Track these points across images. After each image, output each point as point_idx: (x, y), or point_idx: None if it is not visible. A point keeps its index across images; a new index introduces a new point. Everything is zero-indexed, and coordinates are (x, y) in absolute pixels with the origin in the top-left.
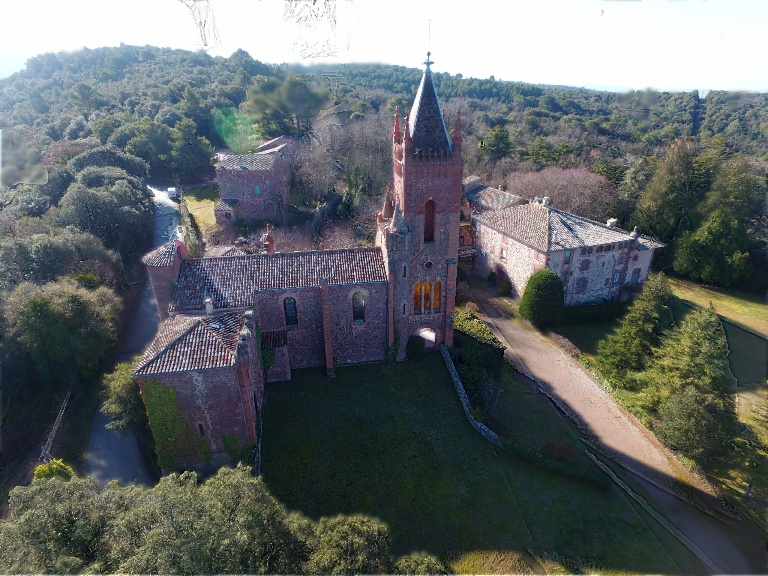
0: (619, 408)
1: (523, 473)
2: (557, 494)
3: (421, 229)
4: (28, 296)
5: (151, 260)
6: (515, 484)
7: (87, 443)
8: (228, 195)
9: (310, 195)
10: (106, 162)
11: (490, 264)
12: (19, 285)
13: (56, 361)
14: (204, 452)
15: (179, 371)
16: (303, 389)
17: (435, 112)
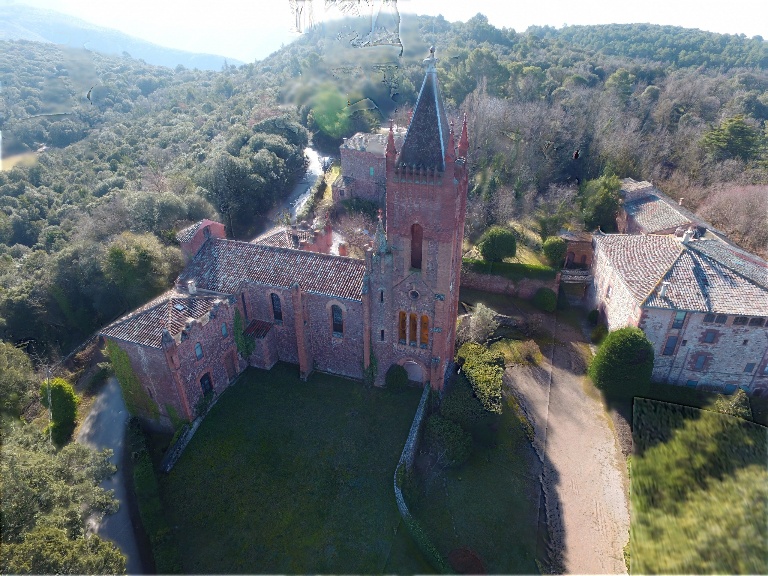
0: None
1: (410, 567)
2: None
3: (405, 254)
4: (110, 245)
5: (180, 234)
6: (389, 575)
7: None
8: (348, 173)
9: None
10: (277, 130)
11: (597, 299)
12: (123, 233)
13: None
14: (154, 411)
15: (125, 340)
16: (271, 383)
17: (432, 121)
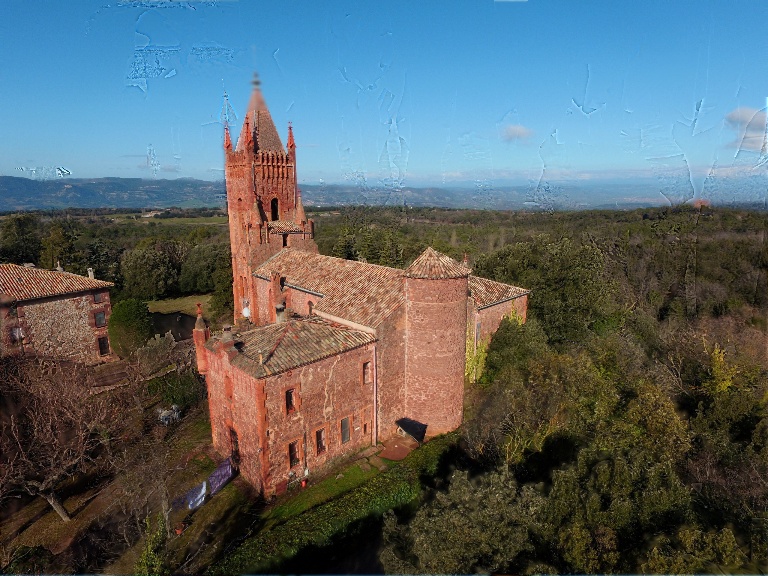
0: None
1: None
2: None
3: None
4: None
5: None
6: None
7: None
8: None
9: None
10: None
11: None
12: None
13: None
14: None
15: None
16: None
17: None
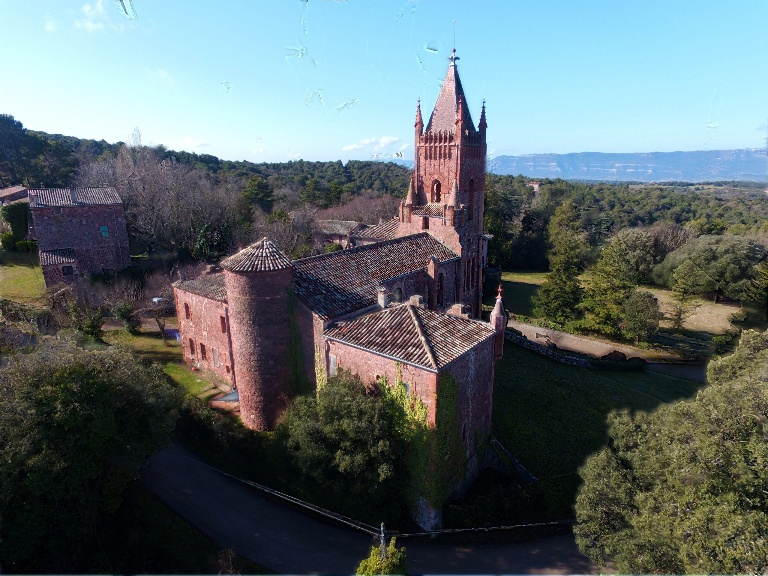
0: (574, 336)
1: (617, 377)
2: (641, 381)
3: None
4: (63, 363)
5: (258, 265)
6: None
7: (264, 568)
8: (53, 244)
9: (181, 232)
10: None
11: None
12: None
13: (55, 502)
14: (462, 464)
15: (468, 350)
16: None
17: (464, 101)
